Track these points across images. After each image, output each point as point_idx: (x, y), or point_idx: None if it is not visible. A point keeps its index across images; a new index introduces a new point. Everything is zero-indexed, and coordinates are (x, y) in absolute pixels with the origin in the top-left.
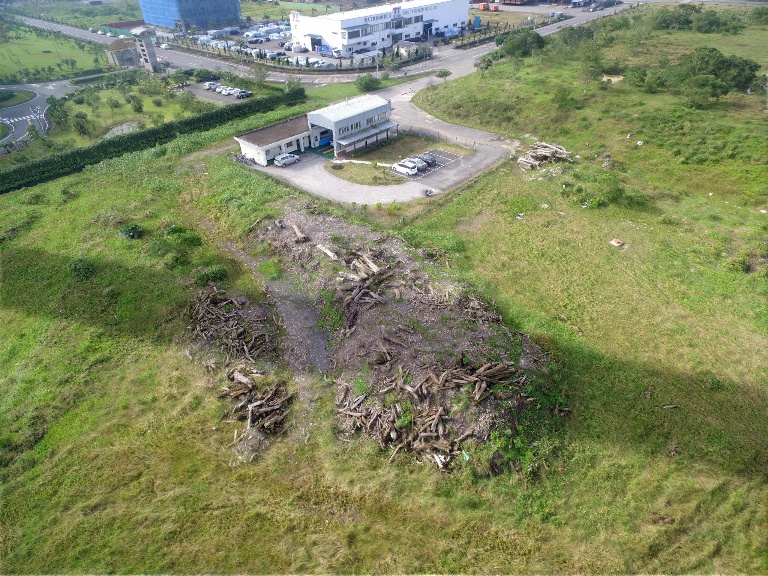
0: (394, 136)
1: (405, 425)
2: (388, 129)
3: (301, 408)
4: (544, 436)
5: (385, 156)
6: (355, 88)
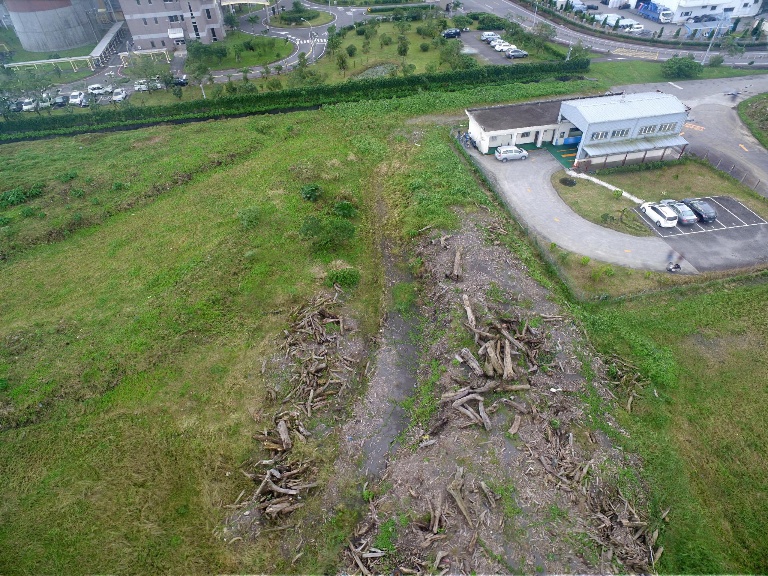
0: (674, 157)
1: None
2: None
3: (316, 510)
4: None
5: (642, 185)
6: (661, 71)
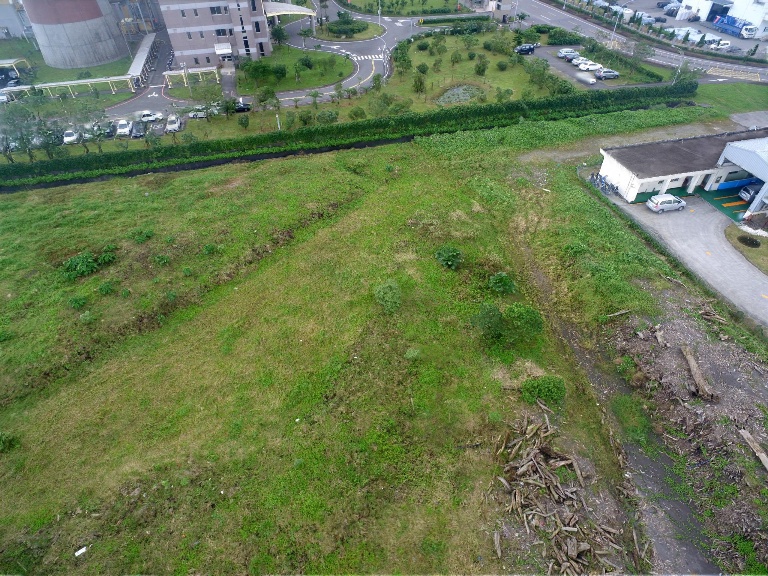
0: None
1: None
2: None
3: None
4: None
5: None
6: None
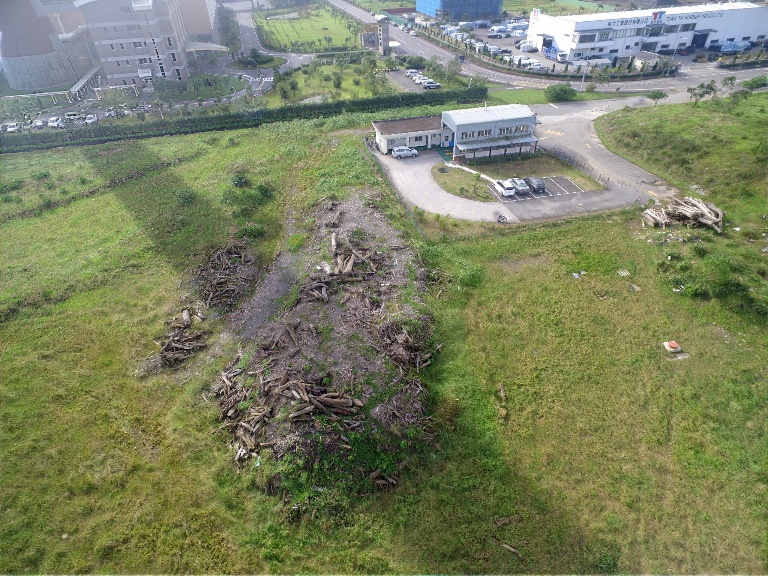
0: (532, 153)
1: (242, 409)
2: (527, 144)
3: (203, 358)
4: (337, 488)
5: (500, 171)
6: None
